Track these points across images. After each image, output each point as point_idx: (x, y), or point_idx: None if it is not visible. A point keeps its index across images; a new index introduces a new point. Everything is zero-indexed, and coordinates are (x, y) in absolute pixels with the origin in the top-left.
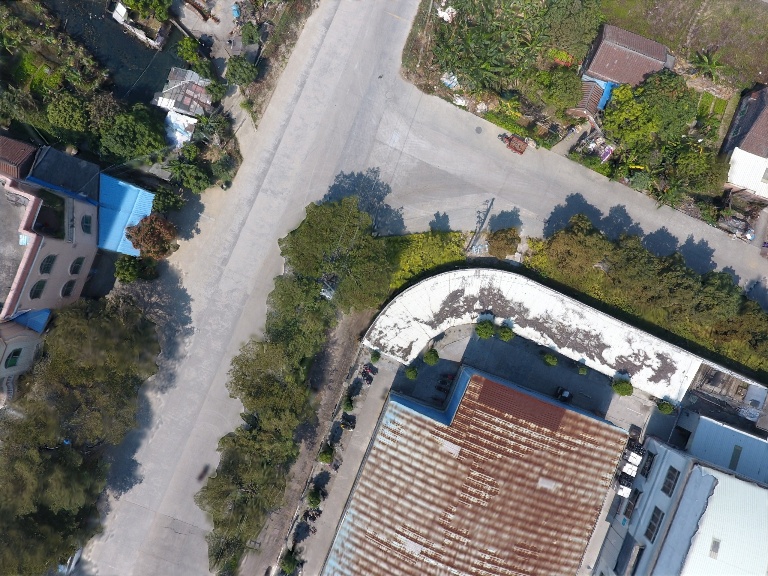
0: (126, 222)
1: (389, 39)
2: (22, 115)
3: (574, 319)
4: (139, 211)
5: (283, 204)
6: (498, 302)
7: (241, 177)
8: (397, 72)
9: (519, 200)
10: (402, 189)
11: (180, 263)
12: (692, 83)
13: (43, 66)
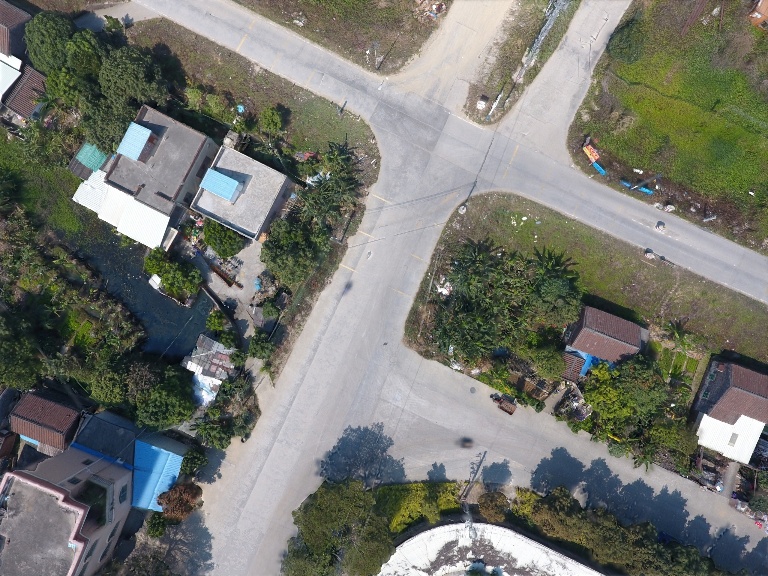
0: (157, 482)
1: (393, 311)
2: (67, 377)
3: (558, 569)
4: (169, 472)
5: (296, 453)
6: (489, 552)
7: (259, 429)
8: (400, 340)
9: (509, 453)
10: (403, 442)
11: (203, 504)
12: (666, 344)
13: (86, 322)
